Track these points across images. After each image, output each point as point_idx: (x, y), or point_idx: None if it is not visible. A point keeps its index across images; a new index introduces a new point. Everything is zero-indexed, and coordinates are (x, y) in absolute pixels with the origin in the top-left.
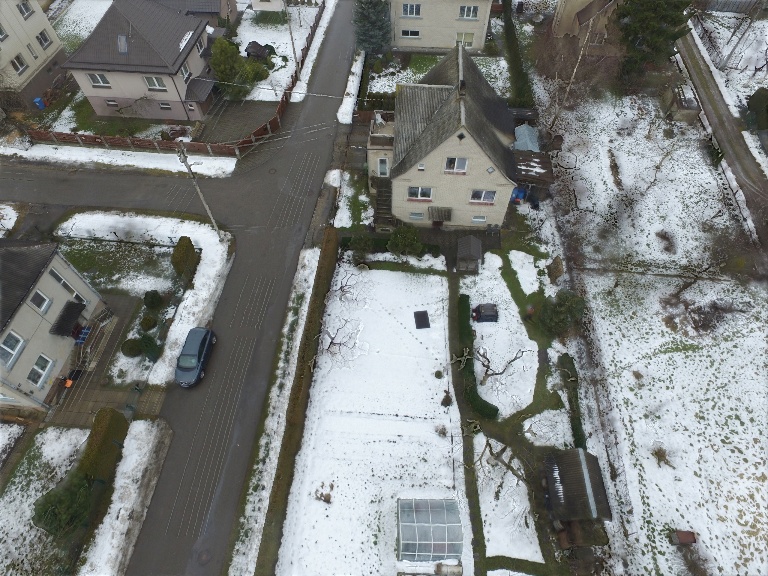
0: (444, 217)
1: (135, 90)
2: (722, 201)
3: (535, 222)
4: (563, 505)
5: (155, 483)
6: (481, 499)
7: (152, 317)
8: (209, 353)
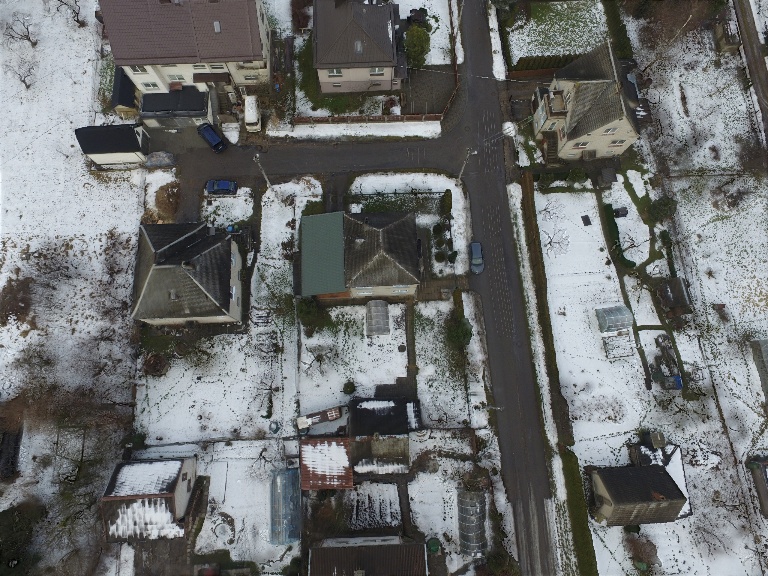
0: (592, 156)
1: (360, 76)
2: (748, 118)
3: (639, 148)
4: (673, 301)
5: (483, 319)
6: (631, 304)
7: None
8: None
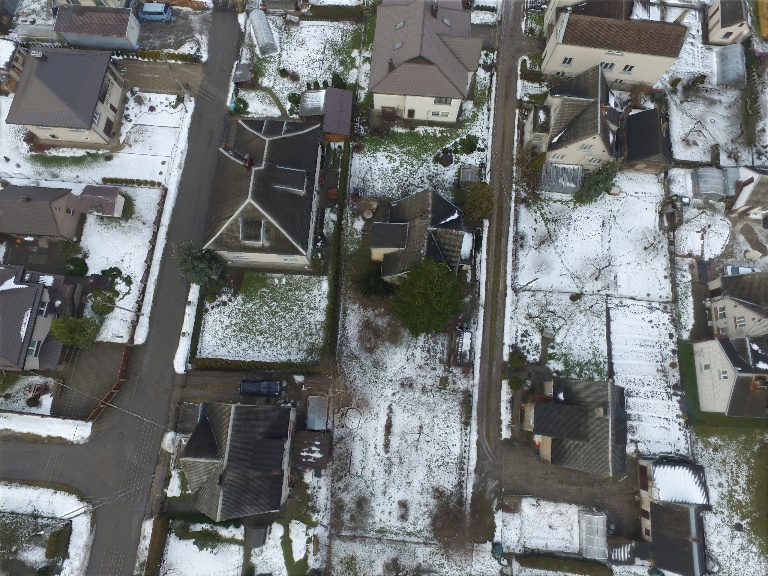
0: None
1: None
2: (458, 466)
3: (314, 491)
4: None
5: None
6: None
7: None
8: None
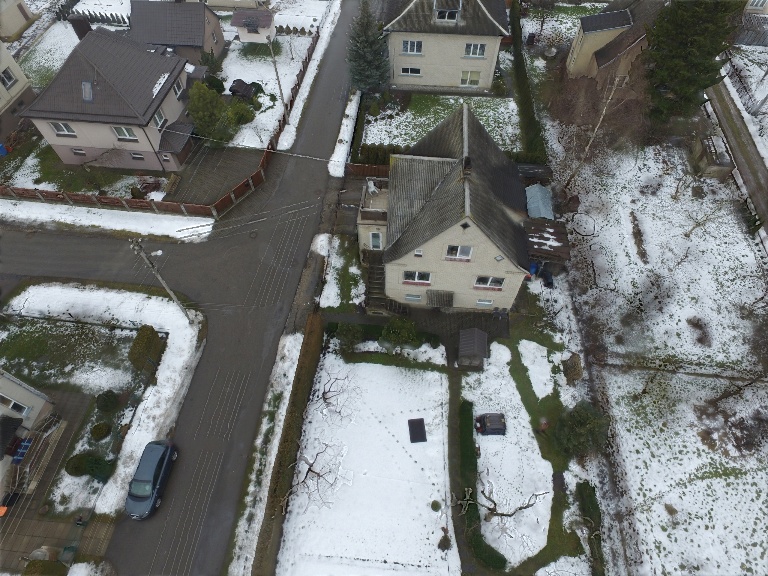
0: (445, 303)
1: (103, 140)
2: (761, 279)
3: (548, 303)
4: None
5: None
6: None
7: (106, 422)
8: (168, 473)
